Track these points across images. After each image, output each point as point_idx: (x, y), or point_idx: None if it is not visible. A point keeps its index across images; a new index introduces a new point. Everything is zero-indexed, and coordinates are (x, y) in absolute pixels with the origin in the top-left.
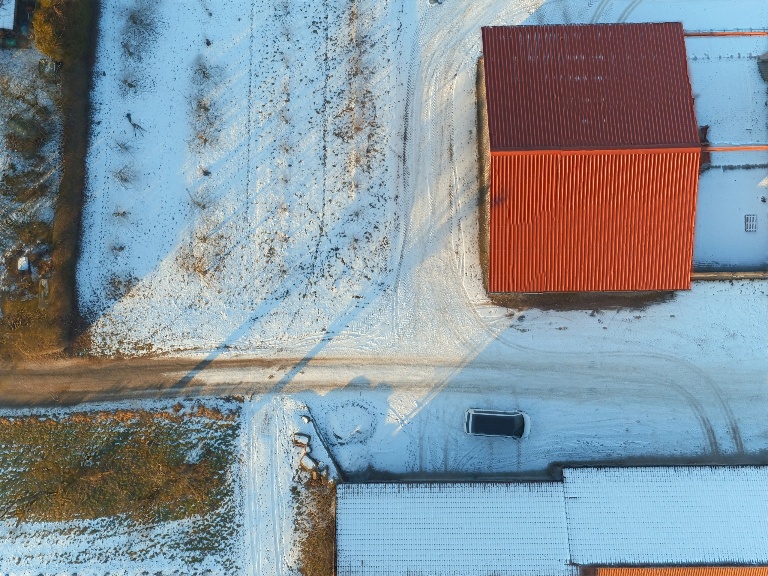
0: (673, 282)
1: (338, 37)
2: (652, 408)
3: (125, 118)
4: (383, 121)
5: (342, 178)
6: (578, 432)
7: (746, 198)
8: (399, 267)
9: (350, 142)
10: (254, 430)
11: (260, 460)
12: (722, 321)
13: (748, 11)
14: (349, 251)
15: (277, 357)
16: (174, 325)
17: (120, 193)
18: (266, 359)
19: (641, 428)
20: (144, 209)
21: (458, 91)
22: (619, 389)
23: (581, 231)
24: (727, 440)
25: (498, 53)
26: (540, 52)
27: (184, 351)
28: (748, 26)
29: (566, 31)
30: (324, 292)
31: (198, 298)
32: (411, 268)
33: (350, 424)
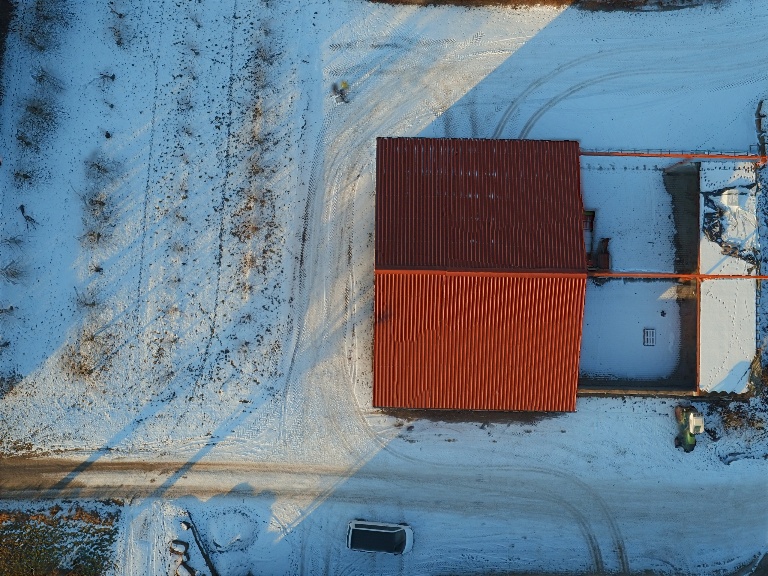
0: (559, 404)
1: (240, 134)
2: (539, 524)
3: (18, 210)
4: (281, 221)
5: (236, 278)
6: (463, 546)
7: (646, 312)
8: (290, 371)
9: (247, 242)
10: (132, 535)
11: (136, 567)
12: (613, 438)
13: (656, 123)
14: (239, 354)
15: (160, 461)
16: (56, 425)
17: (8, 287)
18: (148, 462)
19: (527, 544)
20: (32, 304)
21: (360, 193)
22: (507, 504)
23: (466, 351)
24: (613, 560)
25: (391, 166)
26: (433, 167)
27: (65, 452)
28: (655, 138)
29: (461, 146)
30: (211, 395)
31: (82, 397)
32: (302, 373)
33: (230, 532)
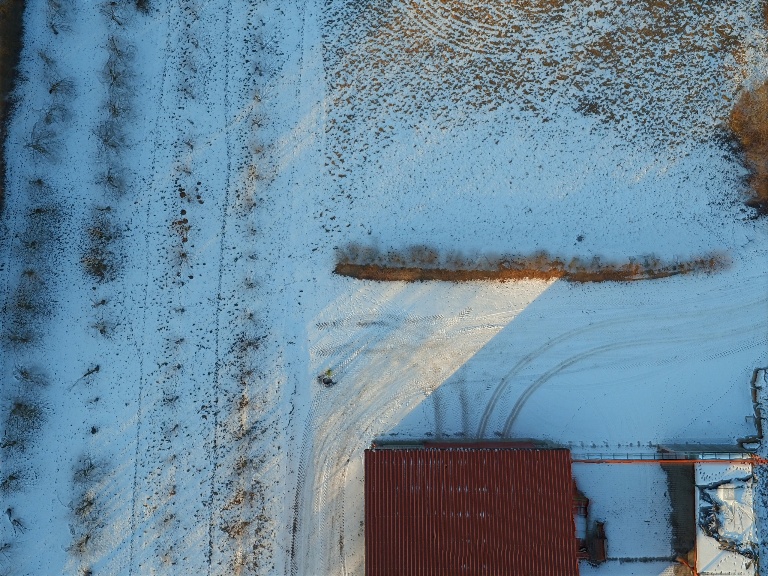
0: None
1: (228, 423)
2: None
3: (5, 514)
4: (271, 514)
5: None
6: None
7: None
8: None
9: (236, 537)
10: None
11: None
12: None
13: (649, 396)
14: None
15: None
16: None
17: None
18: None
19: None
20: None
21: (350, 478)
22: None
23: None
24: None
25: (379, 482)
26: (423, 482)
27: None
28: (648, 412)
29: (450, 457)
30: None
31: None
32: None
33: None
